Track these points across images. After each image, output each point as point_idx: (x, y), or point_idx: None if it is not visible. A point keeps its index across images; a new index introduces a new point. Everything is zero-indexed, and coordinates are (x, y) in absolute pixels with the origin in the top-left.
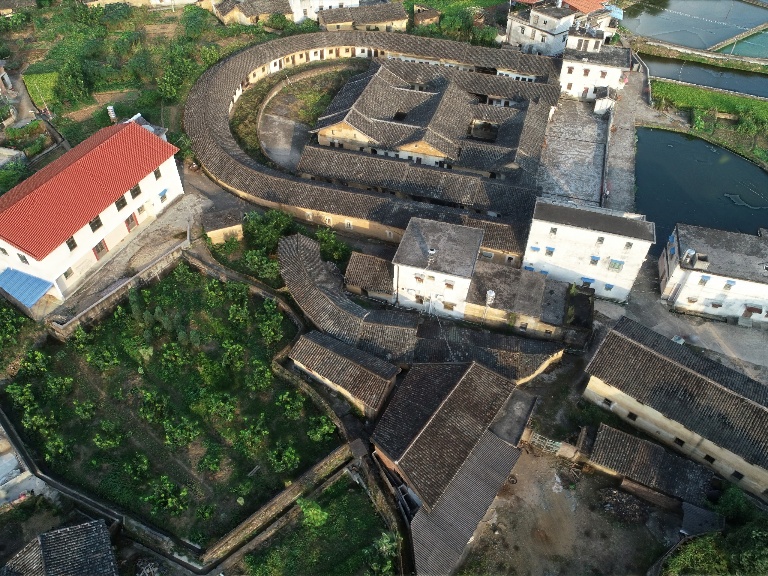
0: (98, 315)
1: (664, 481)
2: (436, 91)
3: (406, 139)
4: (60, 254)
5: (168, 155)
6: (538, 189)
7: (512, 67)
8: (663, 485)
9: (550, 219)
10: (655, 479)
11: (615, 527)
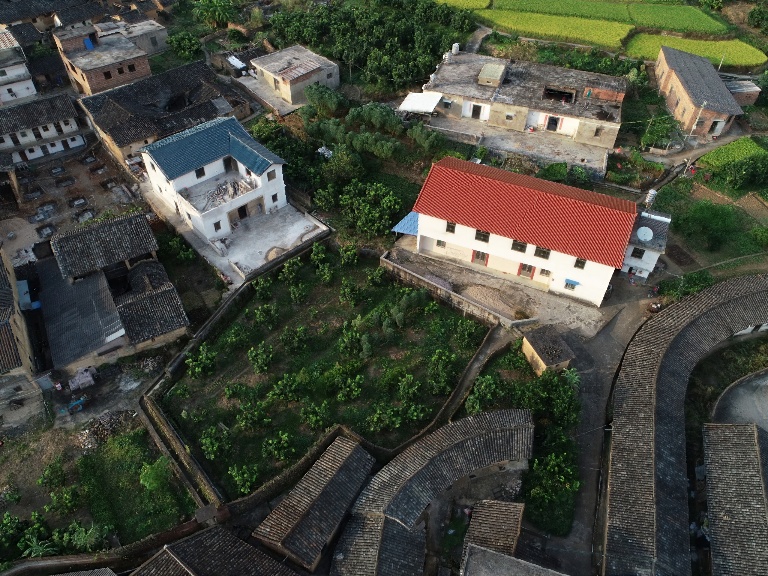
0: (406, 280)
1: None
2: None
3: None
4: (437, 224)
5: (603, 261)
6: None
7: None
8: None
9: None
10: None
11: None
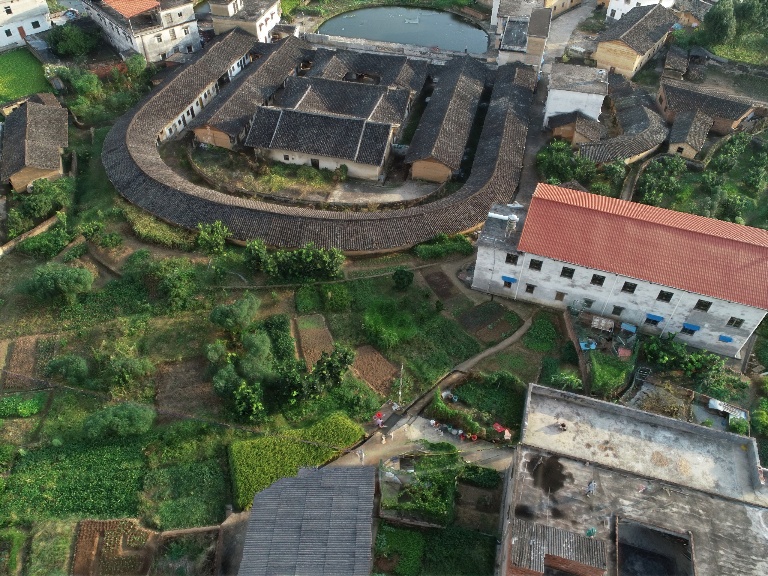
0: None
1: (683, 57)
2: (298, 89)
3: (396, 107)
4: None
5: None
6: (461, 58)
7: (237, 55)
8: (685, 58)
9: (545, 32)
10: (684, 58)
11: (708, 78)
